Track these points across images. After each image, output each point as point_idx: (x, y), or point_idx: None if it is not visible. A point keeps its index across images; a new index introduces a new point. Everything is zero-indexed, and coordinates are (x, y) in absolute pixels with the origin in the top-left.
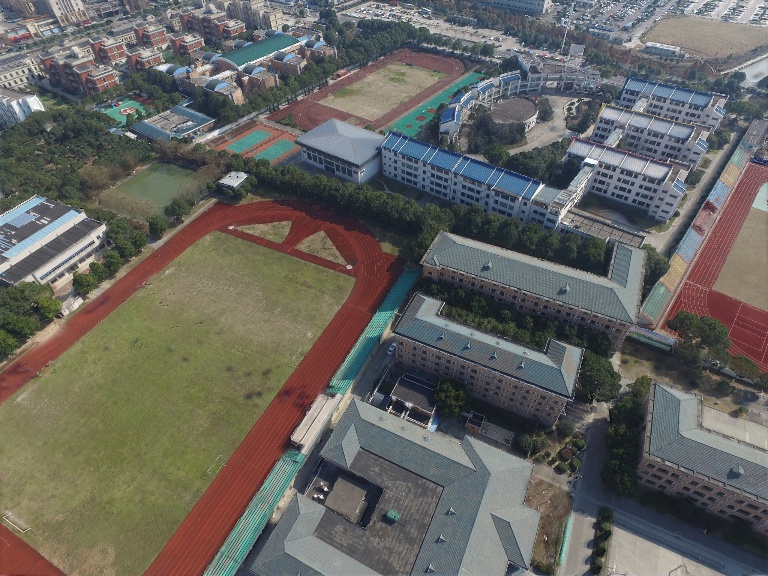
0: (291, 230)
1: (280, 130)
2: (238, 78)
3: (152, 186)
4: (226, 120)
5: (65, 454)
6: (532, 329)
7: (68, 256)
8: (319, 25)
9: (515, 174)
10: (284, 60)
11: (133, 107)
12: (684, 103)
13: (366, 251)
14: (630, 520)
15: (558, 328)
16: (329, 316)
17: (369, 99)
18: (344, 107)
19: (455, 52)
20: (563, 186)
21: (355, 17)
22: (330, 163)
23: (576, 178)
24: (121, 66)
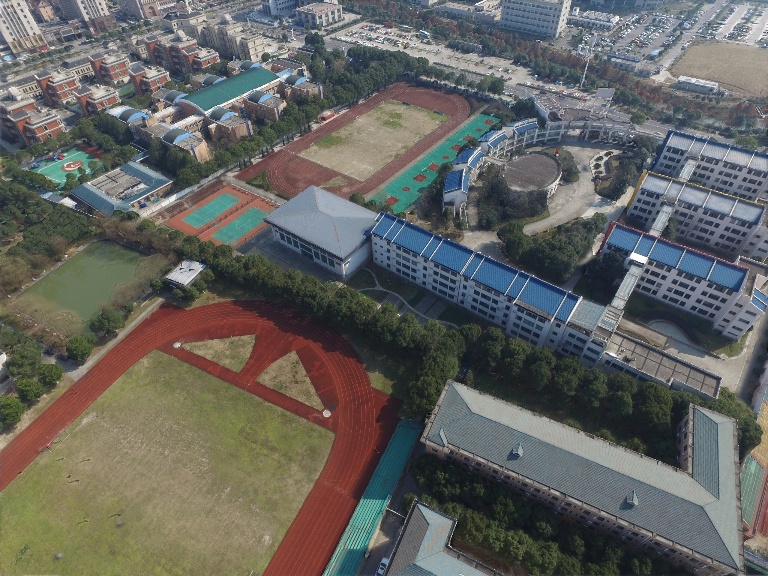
0: (254, 350)
1: (250, 194)
2: (205, 124)
3: (90, 271)
4: (185, 183)
5: None
6: (583, 555)
7: None
8: (303, 55)
9: (544, 283)
10: (260, 102)
11: (79, 160)
12: (742, 167)
13: (349, 386)
14: None
15: (622, 559)
16: (296, 503)
17: (359, 150)
18: (329, 161)
19: (459, 87)
20: (601, 286)
21: (345, 42)
22: (307, 248)
23: (622, 285)
24: (74, 104)
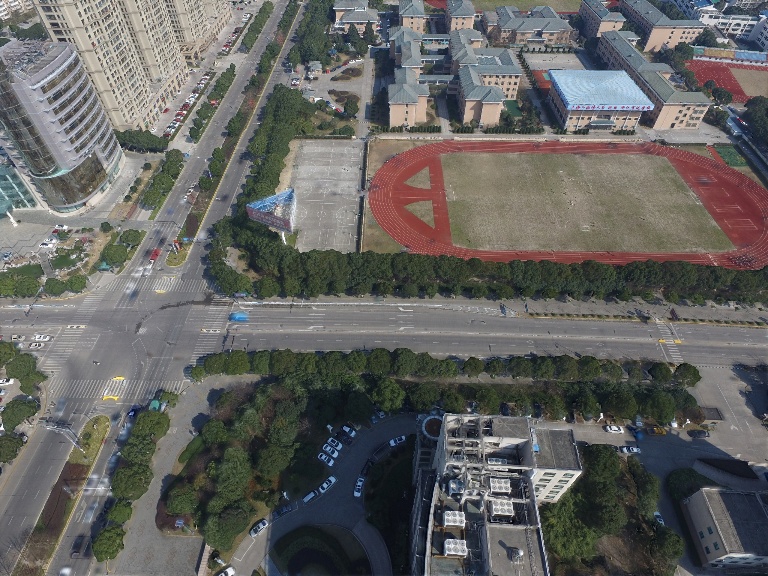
0: None
1: None
2: None
3: None
4: None
5: None
6: None
7: None
8: None
9: None
10: None
11: None
12: None
13: None
14: None
15: None
16: (576, 11)
17: None
18: None
19: None
20: None
21: None
22: None
23: (739, 15)
24: None
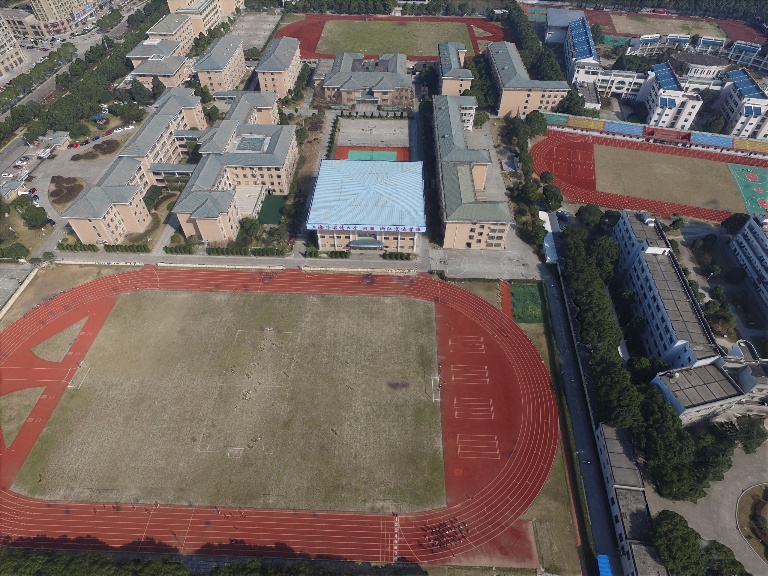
0: (487, 36)
1: None
2: None
3: None
4: None
5: (346, 33)
6: None
7: None
8: None
9: None
10: None
11: None
12: None
13: None
14: (414, 123)
15: None
16: None
17: (642, 26)
18: (619, 22)
19: None
20: None
21: None
22: None
23: (622, 71)
24: None
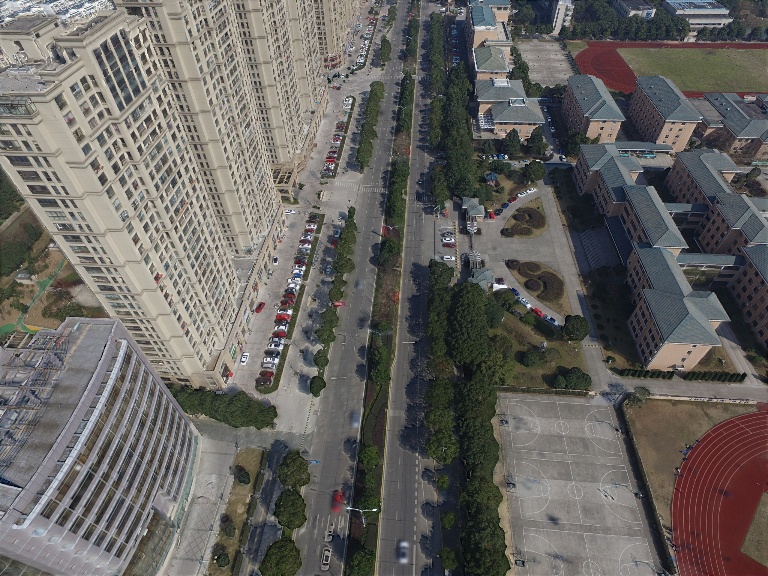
0: None
1: None
2: None
3: None
4: None
5: (656, 64)
6: None
7: (707, 22)
8: None
9: None
10: None
11: None
12: None
13: None
14: None
15: None
16: None
17: None
18: None
19: None
20: None
21: None
22: None
23: None
24: None
